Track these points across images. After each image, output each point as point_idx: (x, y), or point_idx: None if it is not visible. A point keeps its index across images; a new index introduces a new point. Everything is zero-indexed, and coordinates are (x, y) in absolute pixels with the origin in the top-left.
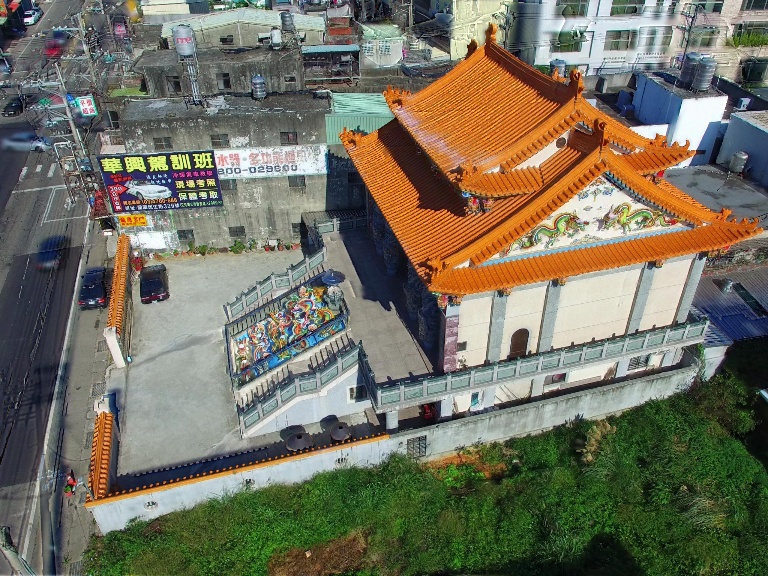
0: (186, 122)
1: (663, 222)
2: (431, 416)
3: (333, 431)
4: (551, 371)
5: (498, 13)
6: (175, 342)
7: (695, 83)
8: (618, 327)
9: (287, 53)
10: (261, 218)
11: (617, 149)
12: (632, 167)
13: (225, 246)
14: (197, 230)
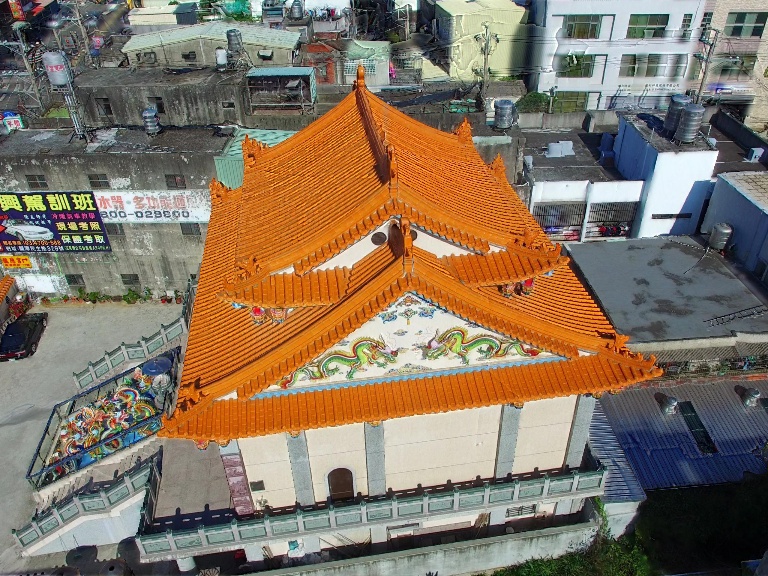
0: (59, 159)
1: (520, 351)
2: (242, 555)
3: (103, 571)
4: (382, 522)
5: (481, 34)
6: (12, 413)
7: (677, 133)
8: (483, 469)
9: (230, 76)
10: (155, 266)
11: (464, 248)
12: (480, 274)
13: (119, 294)
14: (87, 275)
